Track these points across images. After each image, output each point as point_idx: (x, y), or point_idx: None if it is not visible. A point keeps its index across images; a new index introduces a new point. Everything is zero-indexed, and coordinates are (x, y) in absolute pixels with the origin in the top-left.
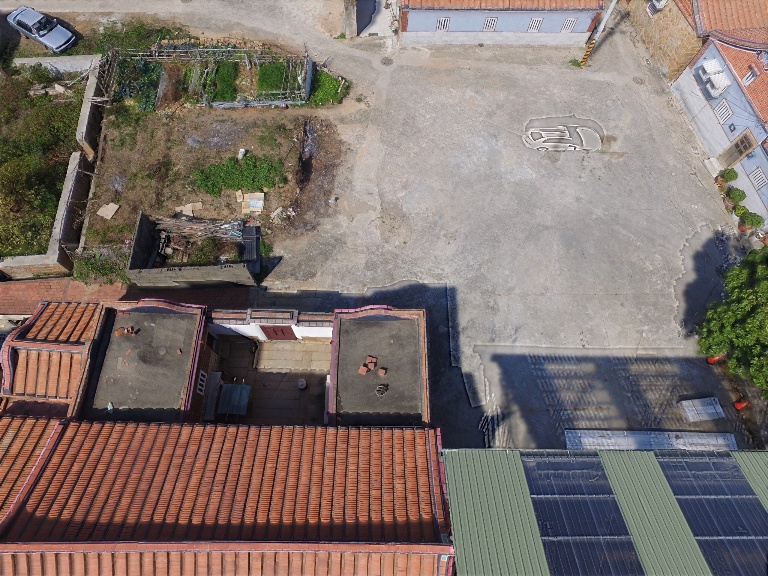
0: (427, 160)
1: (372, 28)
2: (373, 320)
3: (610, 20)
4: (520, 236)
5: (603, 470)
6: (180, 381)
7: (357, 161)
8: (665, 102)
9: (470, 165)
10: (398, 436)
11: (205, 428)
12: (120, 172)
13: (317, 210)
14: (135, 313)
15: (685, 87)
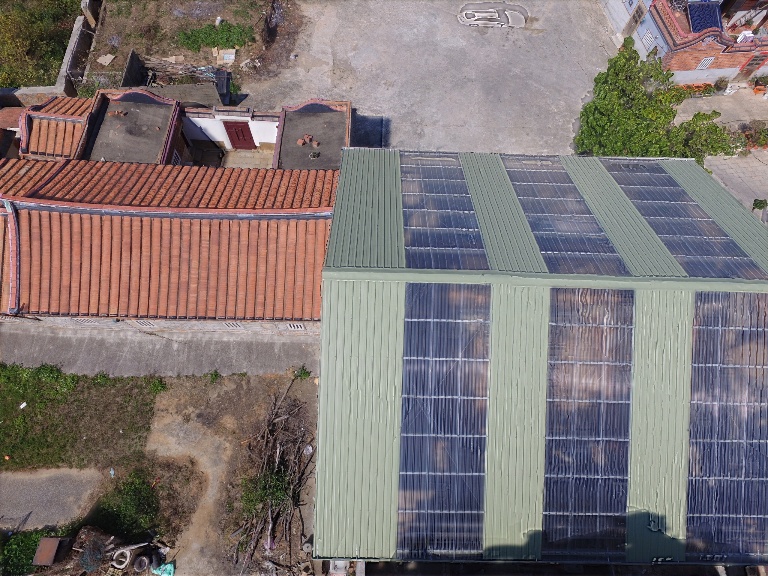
0: (375, 31)
1: None
2: (311, 112)
3: None
4: (448, 85)
5: (458, 159)
6: (158, 147)
7: (315, 30)
8: None
9: (411, 35)
10: (321, 173)
11: (174, 167)
12: (117, 33)
13: (279, 63)
14: (124, 102)
15: None
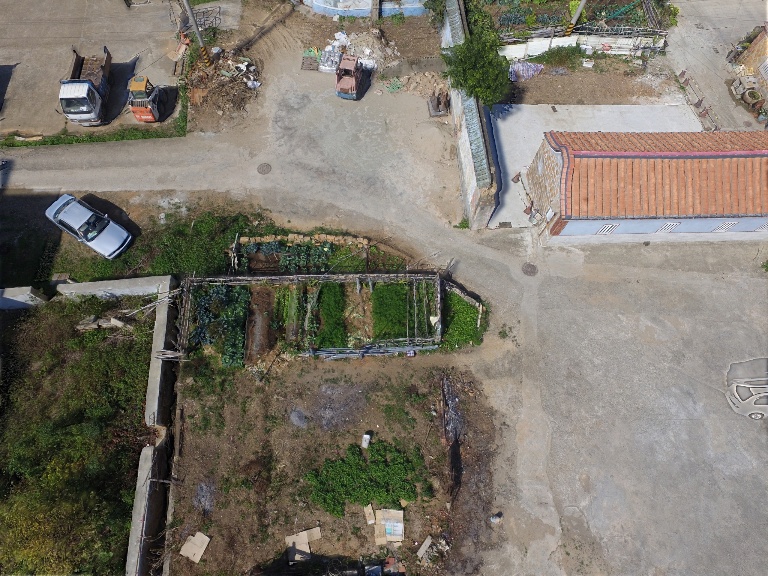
0: (609, 439)
1: (502, 214)
2: None
3: None
4: None
5: None
6: None
7: (518, 446)
8: None
9: (667, 447)
10: None
11: None
12: (206, 475)
13: (476, 537)
14: None
15: None
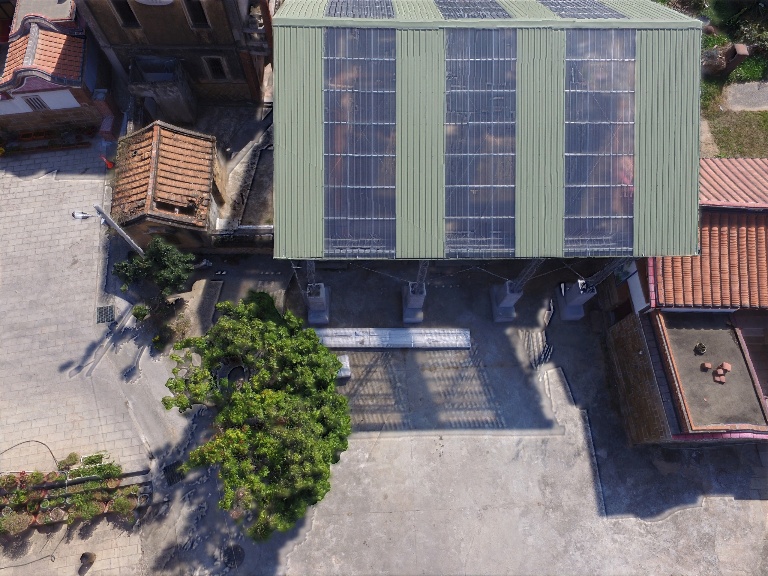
0: None
1: None
2: None
3: None
4: None
5: None
6: None
7: None
8: None
9: None
10: (690, 298)
11: None
12: None
13: None
14: None
15: None
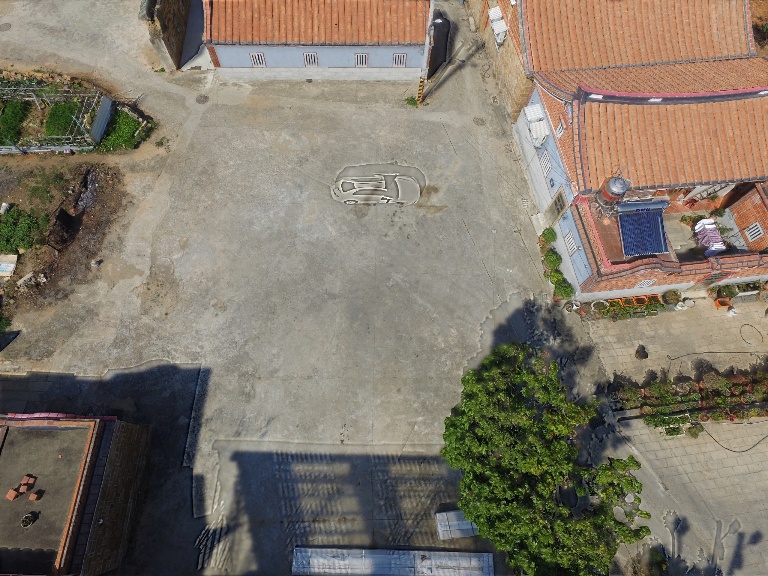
0: (216, 215)
1: (197, 60)
2: (45, 429)
3: (463, 51)
4: (300, 306)
5: None
6: None
7: (135, 217)
8: (503, 146)
9: (264, 221)
10: None
11: None
12: None
13: (75, 275)
14: None
15: (521, 131)
